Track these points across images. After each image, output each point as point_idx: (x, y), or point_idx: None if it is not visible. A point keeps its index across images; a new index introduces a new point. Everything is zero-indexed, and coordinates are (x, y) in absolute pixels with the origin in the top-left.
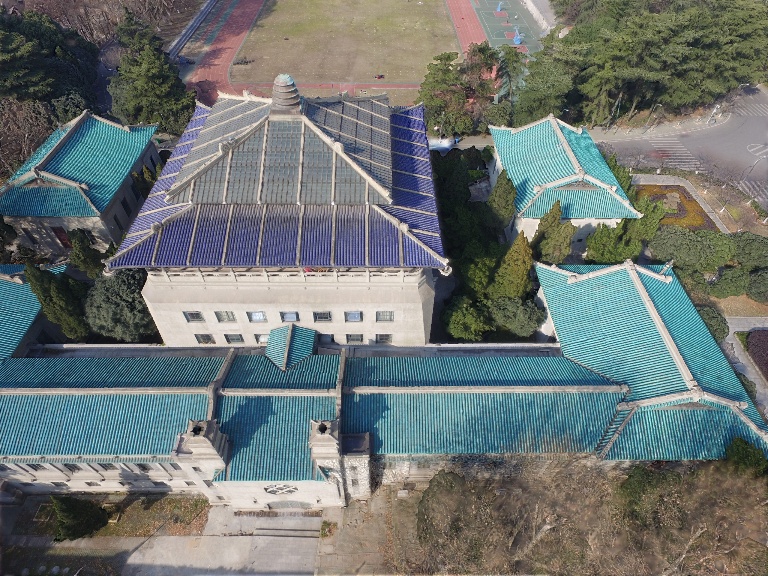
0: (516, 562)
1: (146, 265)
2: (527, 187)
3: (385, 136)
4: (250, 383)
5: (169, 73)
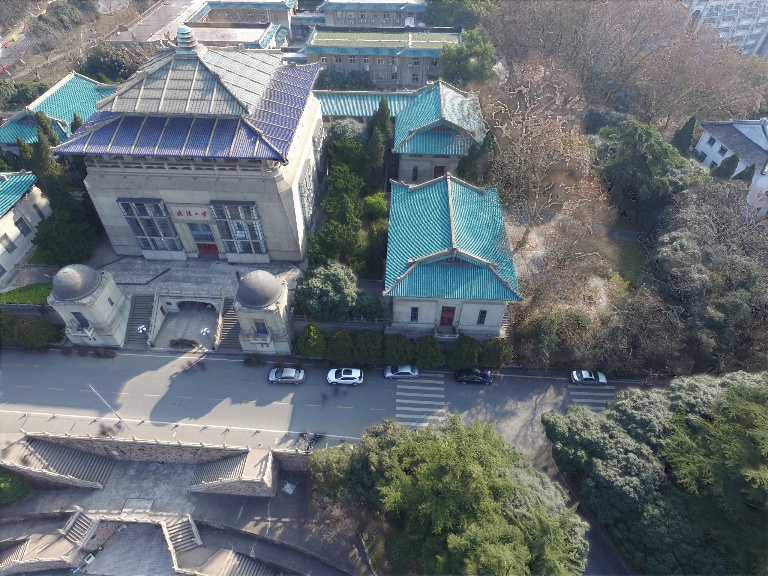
0: None
1: None
2: (7, 186)
3: None
4: None
5: (431, 491)
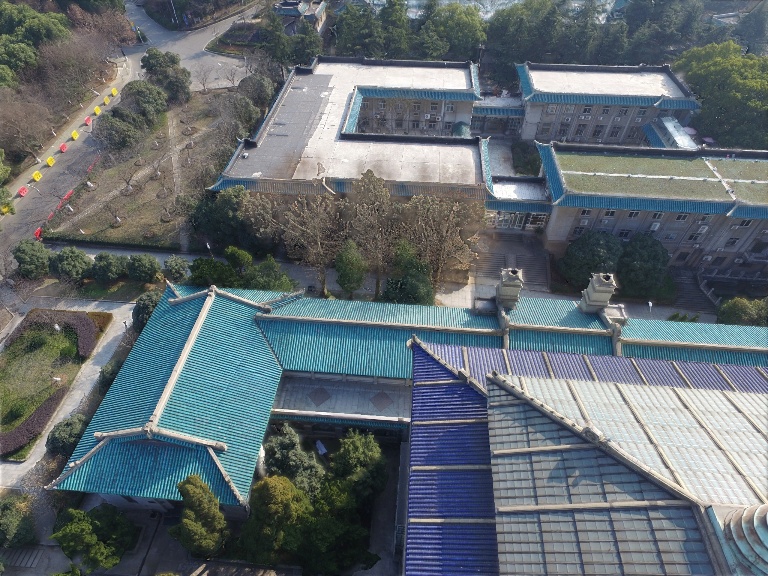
0: (377, 270)
1: (763, 368)
2: None
3: (513, 572)
4: (588, 346)
5: None
